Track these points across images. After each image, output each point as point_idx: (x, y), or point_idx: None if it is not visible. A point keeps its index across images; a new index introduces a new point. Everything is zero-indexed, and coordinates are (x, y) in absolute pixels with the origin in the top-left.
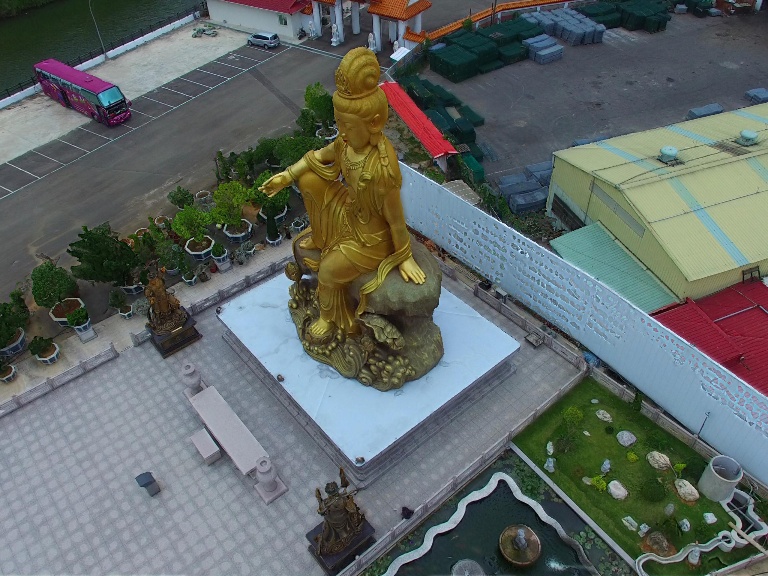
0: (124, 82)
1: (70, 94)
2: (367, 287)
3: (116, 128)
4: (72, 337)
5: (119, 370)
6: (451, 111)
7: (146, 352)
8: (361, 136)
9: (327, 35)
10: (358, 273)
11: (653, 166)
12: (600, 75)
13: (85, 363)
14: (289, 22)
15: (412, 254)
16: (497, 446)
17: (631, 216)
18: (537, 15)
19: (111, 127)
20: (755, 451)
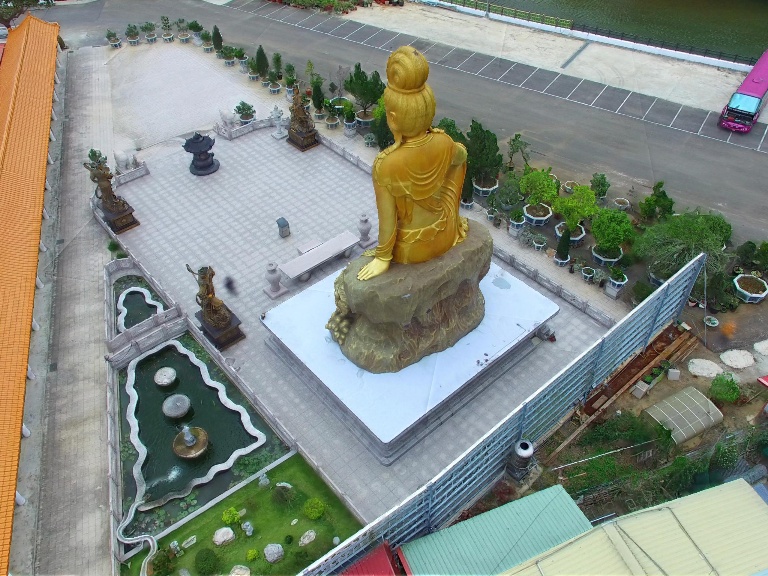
0: None
1: None
2: None
3: (722, 131)
4: None
5: None
6: None
7: None
8: None
9: None
10: None
11: None
12: None
13: None
14: None
15: (398, 269)
16: None
17: None
18: None
19: (721, 127)
20: None
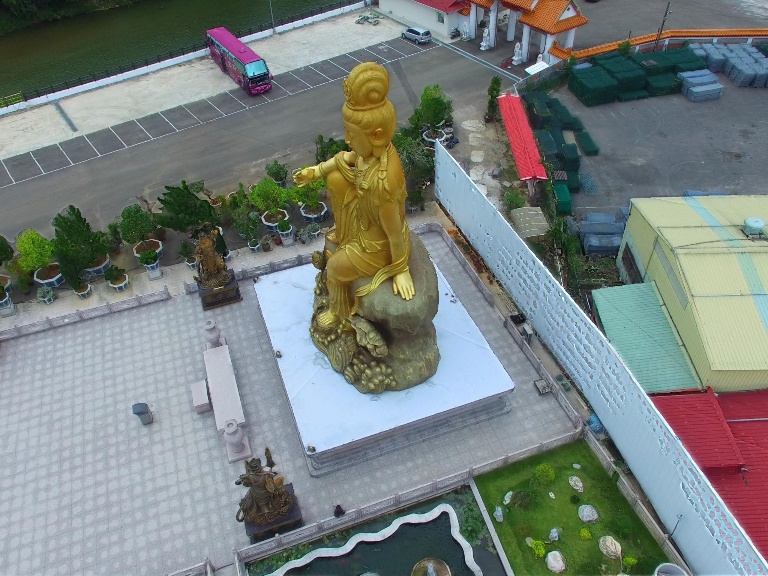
0: (280, 56)
1: (227, 61)
2: (360, 290)
3: (255, 97)
4: (144, 273)
5: (166, 311)
6: (567, 135)
7: (193, 301)
8: (363, 146)
9: (480, 38)
10: (358, 275)
11: (730, 236)
12: (756, 124)
13: (141, 297)
14: (446, 20)
15: (413, 269)
16: (454, 478)
17: (680, 284)
18: (708, 47)
19: (252, 96)
20: (718, 573)
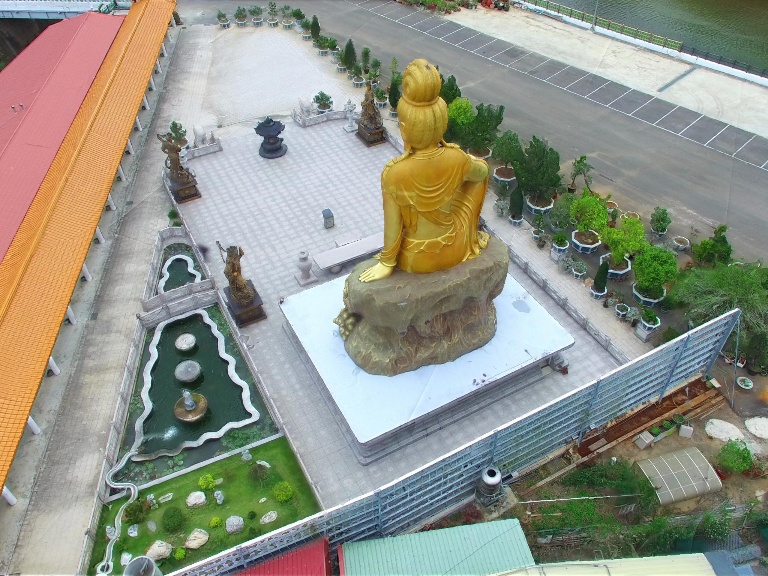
0: None
1: None
2: None
3: None
4: None
5: None
6: None
7: None
8: None
9: None
10: None
11: None
12: None
13: None
14: None
15: (400, 276)
16: None
17: None
18: None
19: None
20: None
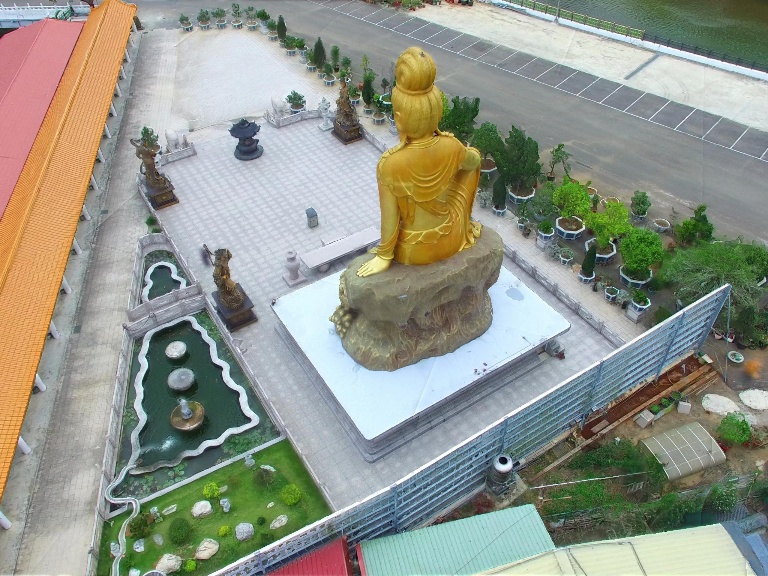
0: None
1: None
2: None
3: None
4: None
5: None
6: None
7: None
8: None
9: None
10: None
11: None
12: None
13: None
14: None
15: (398, 269)
16: None
17: None
18: None
19: None
20: None
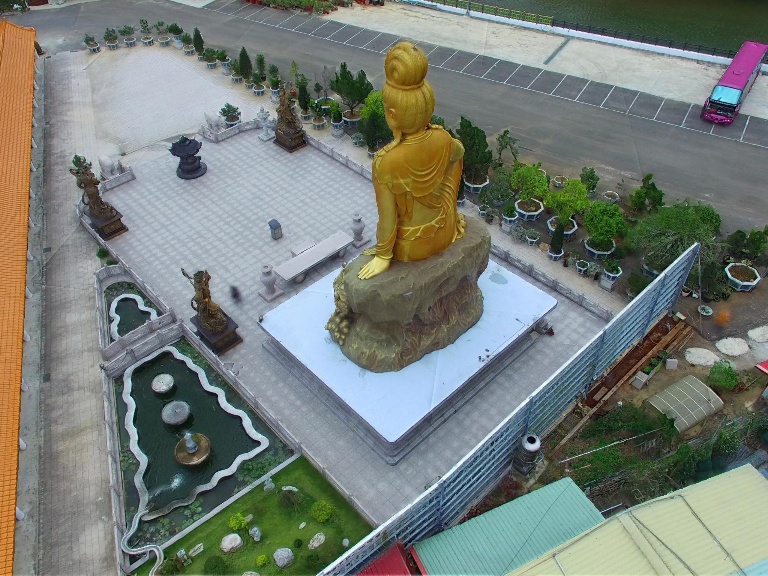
0: None
1: None
2: None
3: (705, 123)
4: None
5: None
6: None
7: None
8: None
9: None
10: None
11: None
12: None
13: None
14: None
15: (399, 267)
16: None
17: None
18: None
19: (704, 119)
20: None
